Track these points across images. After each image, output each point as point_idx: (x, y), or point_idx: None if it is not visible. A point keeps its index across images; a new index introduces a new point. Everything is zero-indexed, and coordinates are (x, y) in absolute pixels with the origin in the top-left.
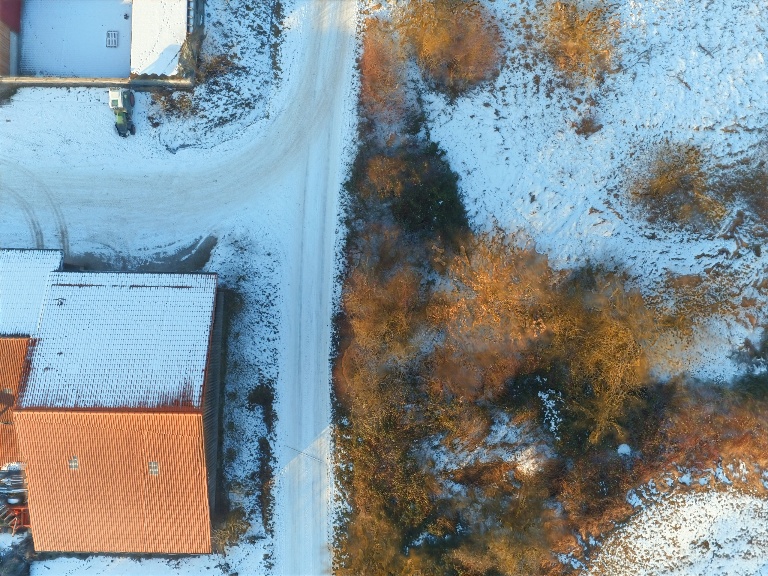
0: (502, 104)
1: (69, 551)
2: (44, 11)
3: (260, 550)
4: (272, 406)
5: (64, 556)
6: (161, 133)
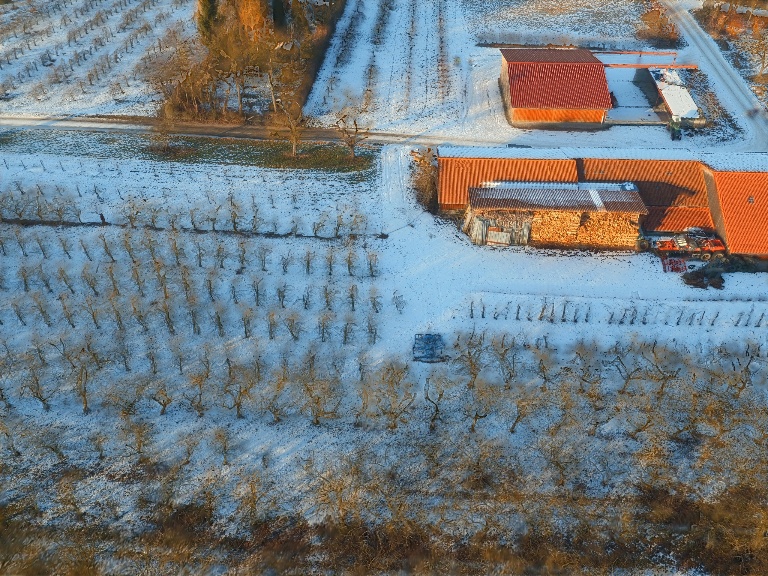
0: None
1: (753, 254)
2: None
3: None
4: None
5: (740, 270)
6: (695, 140)
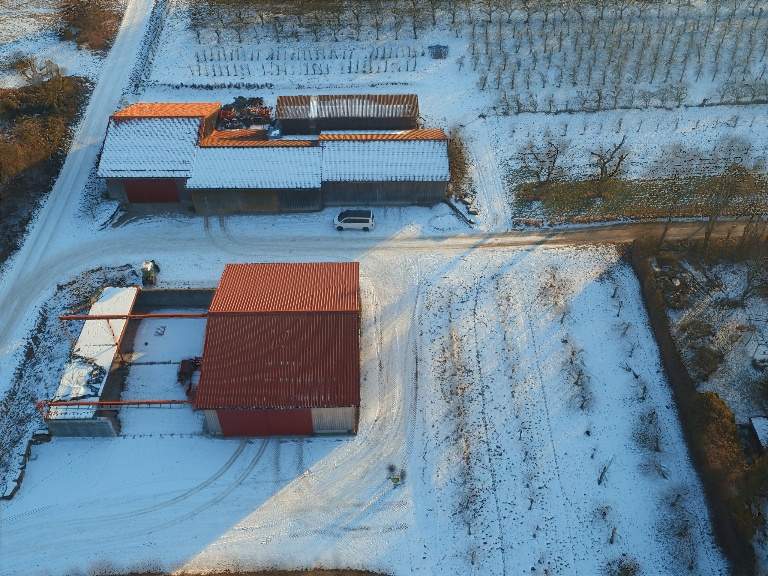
0: None
1: None
2: None
3: None
4: (98, 160)
5: None
6: None
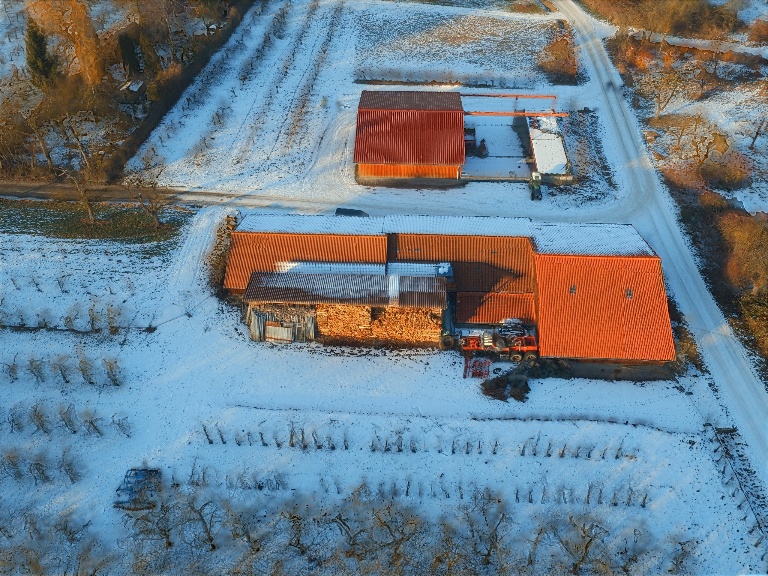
0: (761, 193)
1: (567, 357)
2: (472, 165)
3: (704, 381)
4: (677, 309)
5: (553, 376)
6: (557, 200)
